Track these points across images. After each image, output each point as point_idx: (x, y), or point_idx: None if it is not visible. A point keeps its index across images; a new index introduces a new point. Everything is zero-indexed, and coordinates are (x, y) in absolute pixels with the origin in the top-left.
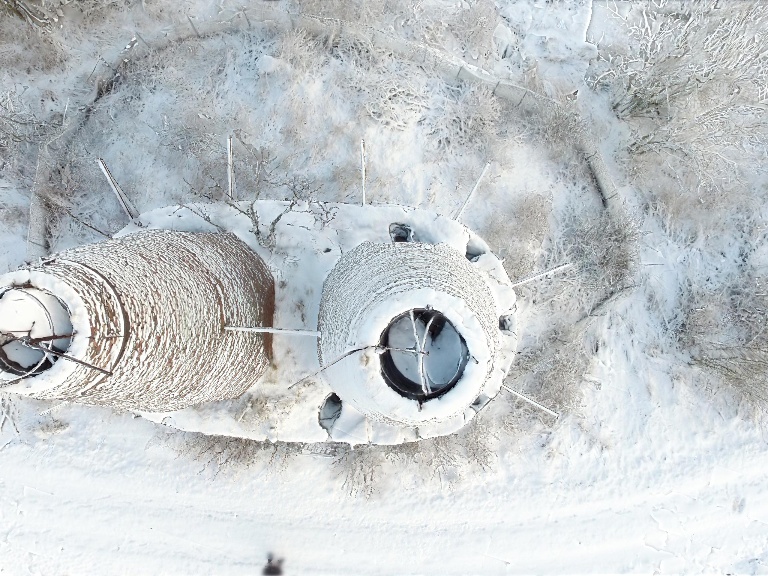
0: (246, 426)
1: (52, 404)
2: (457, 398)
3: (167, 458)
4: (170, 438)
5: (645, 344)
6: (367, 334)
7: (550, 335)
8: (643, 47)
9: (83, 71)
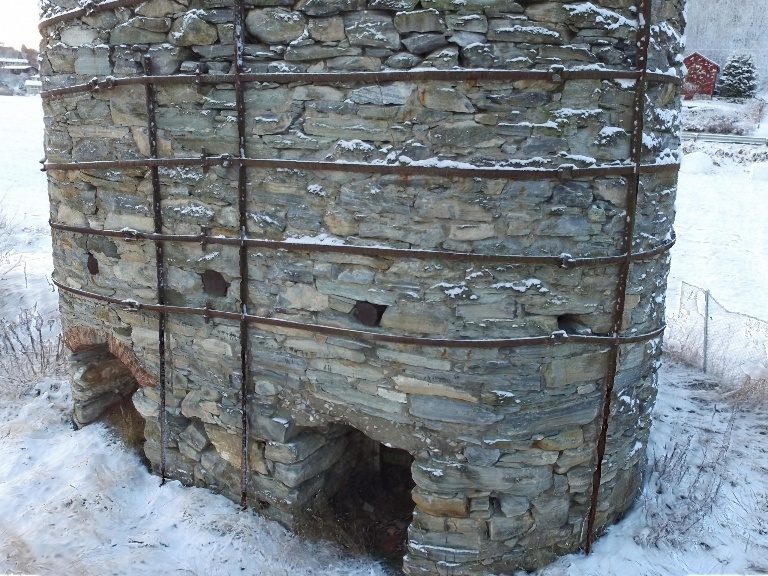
0: None
1: None
2: None
3: None
4: None
5: None
6: None
7: None
8: None
9: None
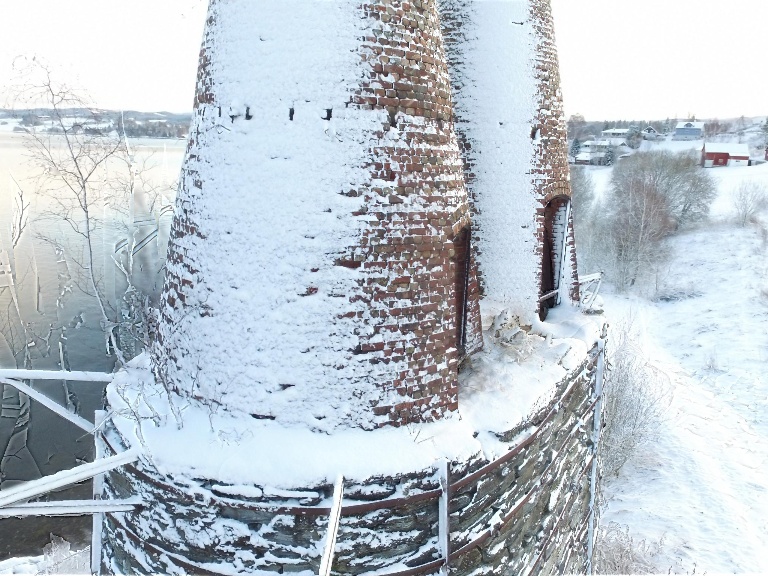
0: (533, 361)
1: None
2: None
3: None
4: None
5: None
6: None
7: None
8: None
9: None
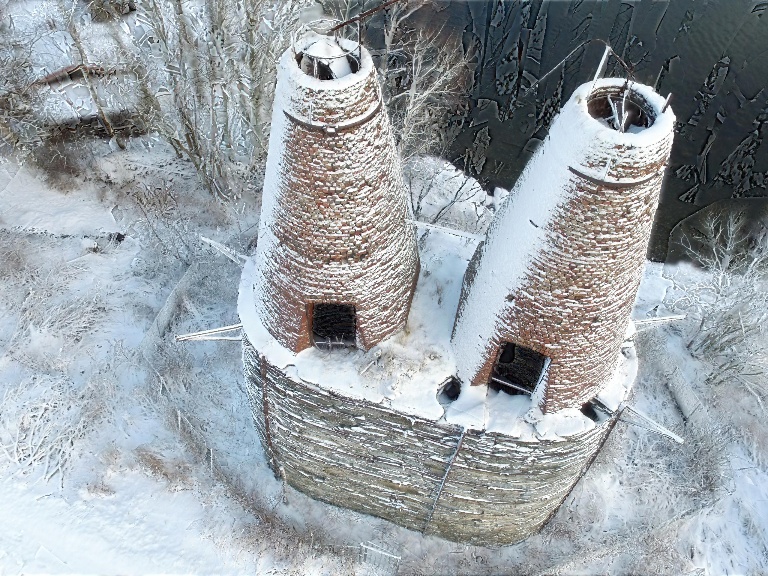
0: (367, 381)
1: (109, 467)
2: (650, 133)
3: (202, 553)
4: (216, 525)
5: (747, 568)
6: (579, 91)
7: (638, 525)
8: (714, 283)
9: (241, 233)
